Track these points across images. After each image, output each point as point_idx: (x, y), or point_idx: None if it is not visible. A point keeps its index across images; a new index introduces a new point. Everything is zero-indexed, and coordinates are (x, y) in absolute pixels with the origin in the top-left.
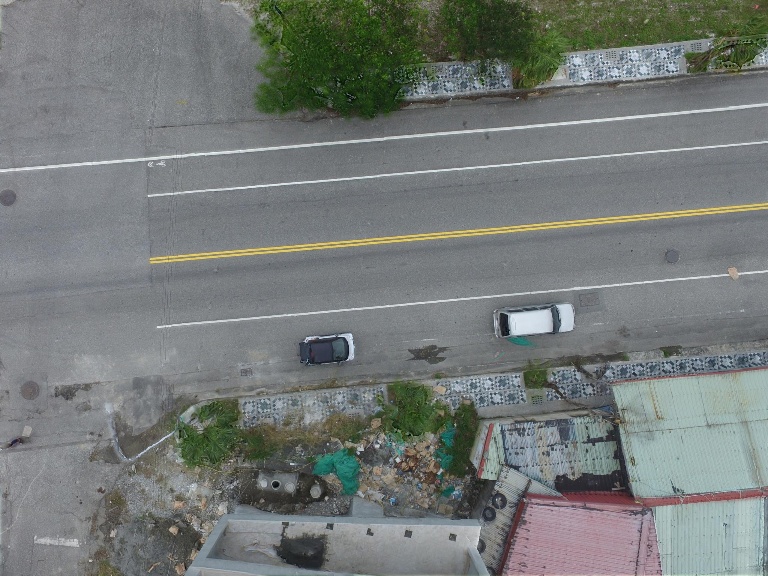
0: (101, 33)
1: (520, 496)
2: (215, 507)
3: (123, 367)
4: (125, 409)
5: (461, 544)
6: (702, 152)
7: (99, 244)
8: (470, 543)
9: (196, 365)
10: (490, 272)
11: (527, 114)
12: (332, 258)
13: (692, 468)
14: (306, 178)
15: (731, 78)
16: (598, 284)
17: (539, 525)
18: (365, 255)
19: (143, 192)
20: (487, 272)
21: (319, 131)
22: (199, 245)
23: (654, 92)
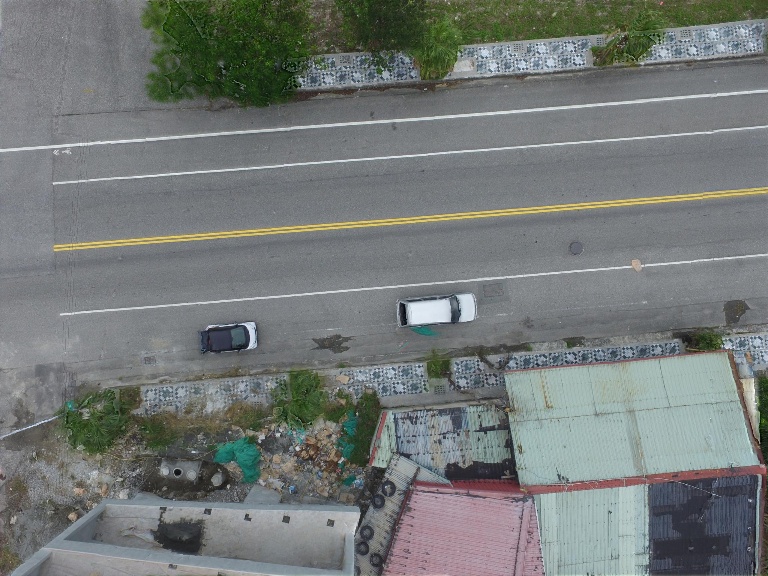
0: (10, 20)
1: (409, 483)
2: (116, 494)
3: (26, 354)
4: (27, 396)
5: (339, 530)
6: (608, 145)
7: (3, 231)
8: (348, 529)
9: (99, 353)
10: (395, 262)
11: (434, 105)
12: (237, 247)
13: (578, 456)
14: (212, 167)
15: (638, 71)
16: (502, 275)
17: (423, 512)
18: (270, 244)
19: (48, 180)
20: (392, 262)
21: (226, 120)
22: (104, 233)
23: (561, 85)
